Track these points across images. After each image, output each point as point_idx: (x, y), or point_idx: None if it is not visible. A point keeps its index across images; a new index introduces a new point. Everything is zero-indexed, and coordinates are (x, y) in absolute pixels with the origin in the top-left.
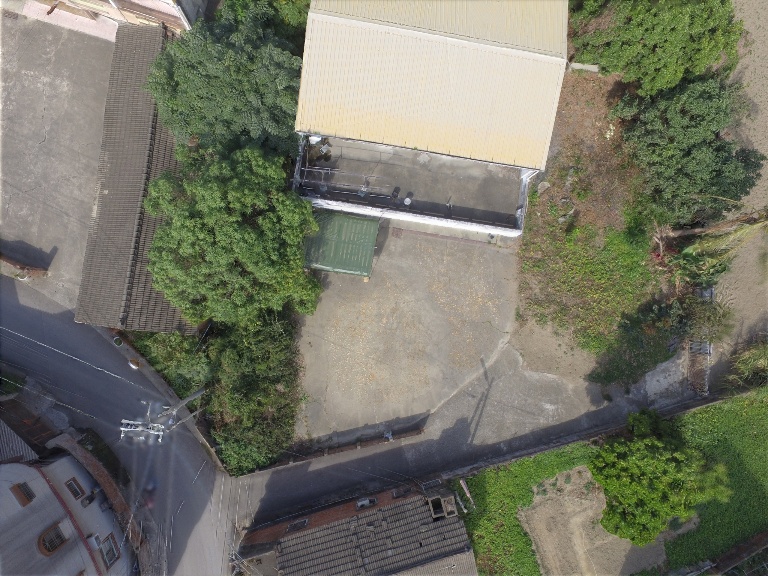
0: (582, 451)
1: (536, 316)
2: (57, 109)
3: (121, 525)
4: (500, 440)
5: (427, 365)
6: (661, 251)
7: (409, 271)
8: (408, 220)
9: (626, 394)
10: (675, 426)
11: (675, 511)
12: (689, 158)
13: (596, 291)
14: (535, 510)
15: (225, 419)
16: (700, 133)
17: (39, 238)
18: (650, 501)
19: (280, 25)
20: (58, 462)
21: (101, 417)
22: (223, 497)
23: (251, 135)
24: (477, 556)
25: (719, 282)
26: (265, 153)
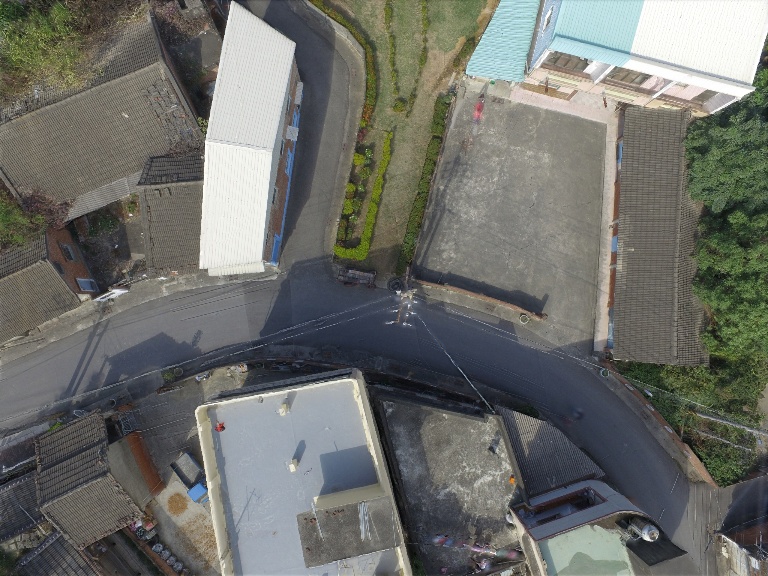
0: None
1: None
2: (542, 177)
3: None
4: None
5: None
6: None
7: None
8: None
9: None
10: None
11: None
12: None
13: None
14: None
15: (701, 437)
16: None
17: (533, 287)
18: None
19: None
20: None
21: (591, 438)
22: (697, 505)
23: None
24: None
25: None
26: None
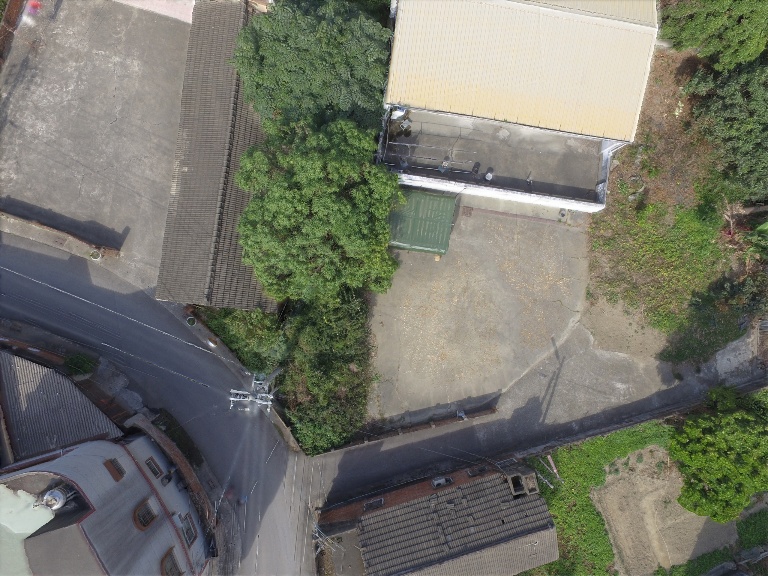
0: (654, 430)
1: (607, 295)
2: (128, 89)
3: (196, 505)
4: (572, 419)
5: (498, 344)
6: (731, 229)
7: (480, 250)
8: (487, 196)
9: (697, 373)
10: (749, 404)
11: (767, 485)
12: None
13: (667, 269)
14: (607, 489)
15: (299, 399)
16: None
17: (111, 218)
18: (736, 477)
19: None
20: (137, 441)
21: (174, 397)
22: (296, 477)
23: (341, 108)
24: None
25: None
26: None
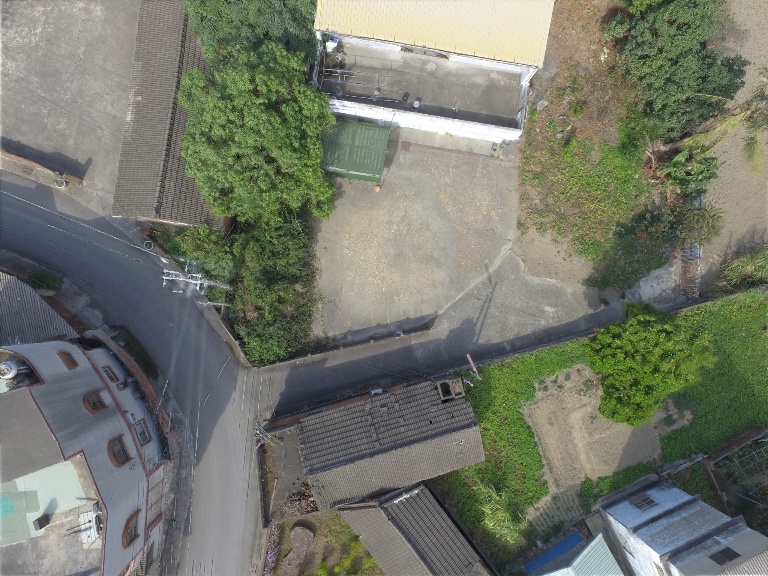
0: (581, 350)
1: (536, 224)
2: (91, 32)
3: (151, 415)
4: (504, 340)
5: (435, 269)
6: (653, 165)
7: (417, 182)
8: (417, 124)
9: (622, 298)
10: None
11: (666, 380)
12: (677, 66)
13: (592, 201)
14: (537, 405)
15: (247, 317)
16: (686, 40)
17: (75, 150)
18: (643, 378)
19: None
20: (95, 350)
21: (132, 316)
22: (246, 391)
23: (275, 34)
24: (483, 447)
25: (708, 192)
26: None
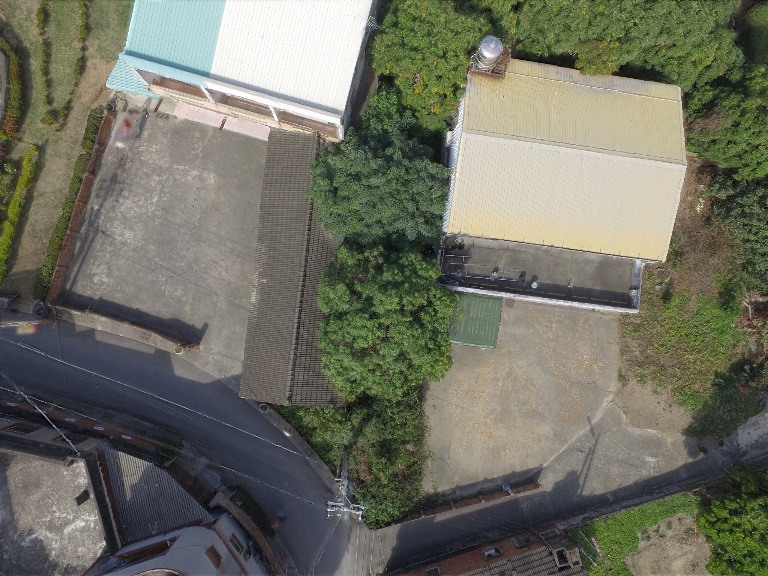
0: (682, 500)
1: (637, 376)
2: (205, 199)
3: (270, 574)
4: (607, 491)
5: (539, 423)
6: (750, 314)
7: (521, 338)
8: None
9: (720, 446)
10: None
11: None
12: None
13: (691, 352)
14: (640, 555)
15: (361, 477)
16: None
17: (192, 316)
18: (760, 553)
19: (417, 129)
20: (220, 520)
21: None
22: (358, 547)
23: (409, 238)
24: None
25: None
26: (411, 247)
